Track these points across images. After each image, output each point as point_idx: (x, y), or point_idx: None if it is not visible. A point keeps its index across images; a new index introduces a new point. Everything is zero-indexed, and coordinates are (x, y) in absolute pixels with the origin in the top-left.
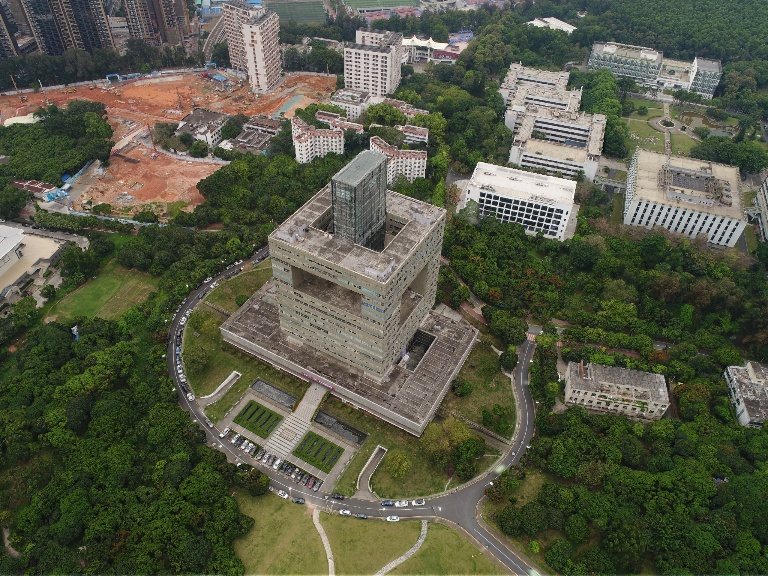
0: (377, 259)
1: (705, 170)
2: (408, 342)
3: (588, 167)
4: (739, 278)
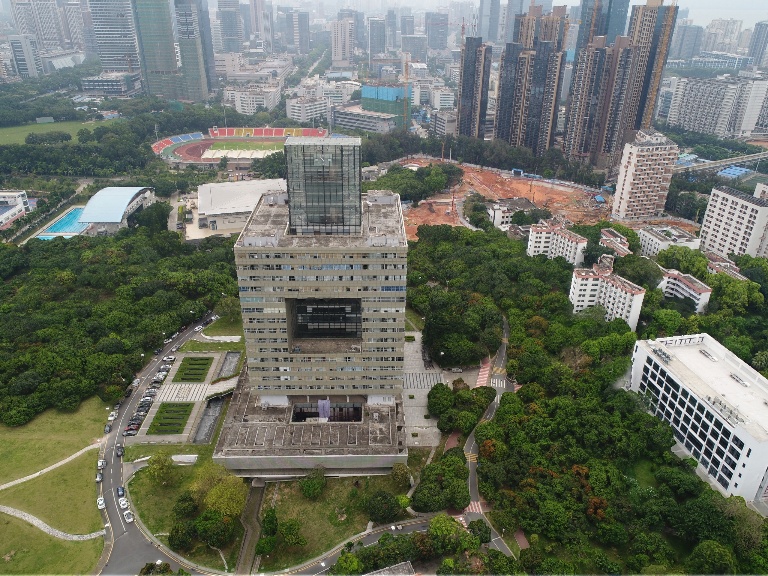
0: (265, 230)
1: None
2: (338, 406)
3: None
4: None
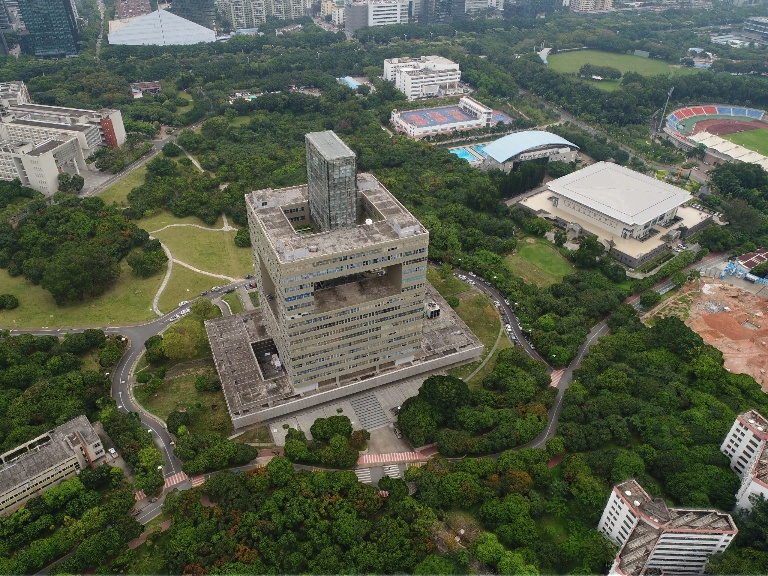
0: (270, 195)
1: None
2: None
3: None
4: None
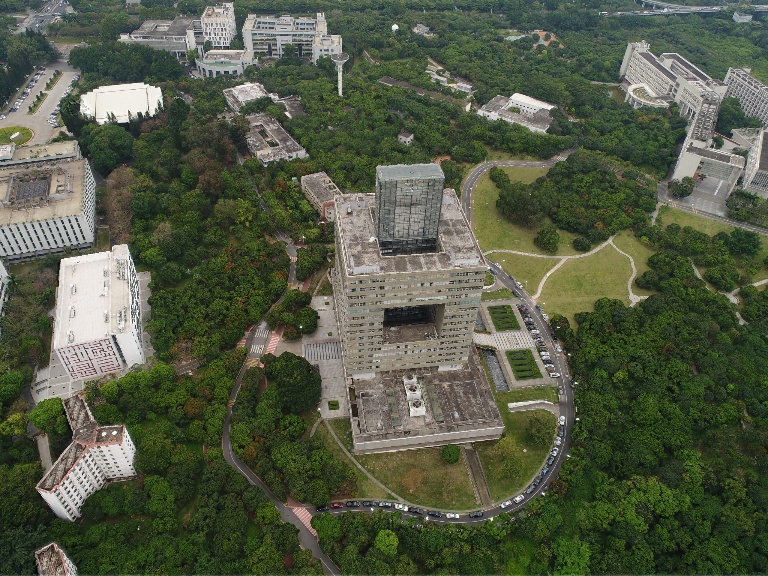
0: None
1: (2, 181)
2: None
3: (1, 271)
4: (153, 169)
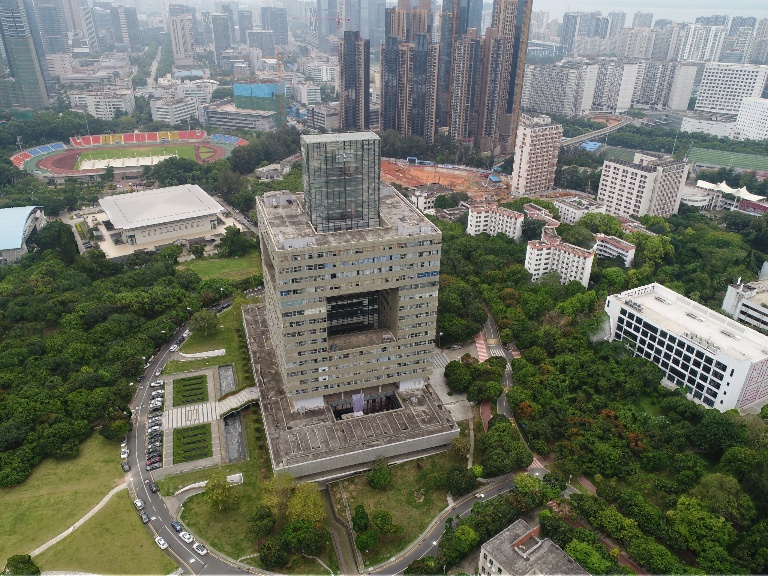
0: (299, 231)
1: None
2: (371, 398)
3: None
4: None
